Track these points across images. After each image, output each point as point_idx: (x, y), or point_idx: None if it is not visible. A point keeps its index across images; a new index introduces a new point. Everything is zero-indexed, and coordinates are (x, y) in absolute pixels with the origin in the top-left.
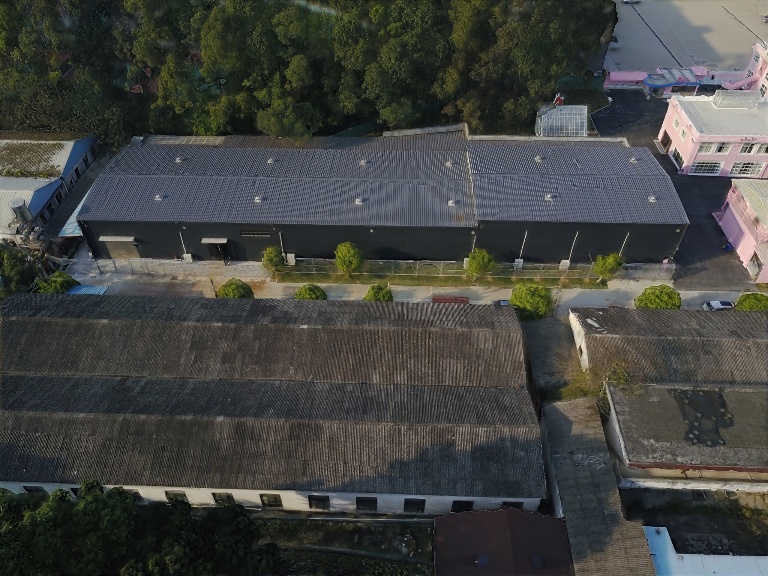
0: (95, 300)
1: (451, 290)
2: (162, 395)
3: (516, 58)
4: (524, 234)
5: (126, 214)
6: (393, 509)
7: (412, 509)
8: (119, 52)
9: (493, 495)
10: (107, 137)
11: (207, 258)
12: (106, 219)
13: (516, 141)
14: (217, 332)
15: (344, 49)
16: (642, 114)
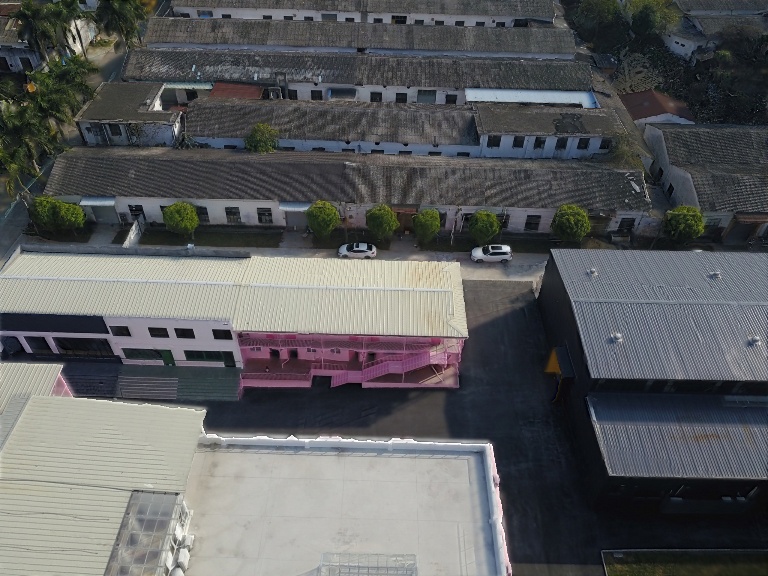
0: None
1: None
2: None
3: None
4: None
5: None
6: None
7: None
8: None
9: None
10: None
11: None
12: None
13: None
14: None
15: None
16: None
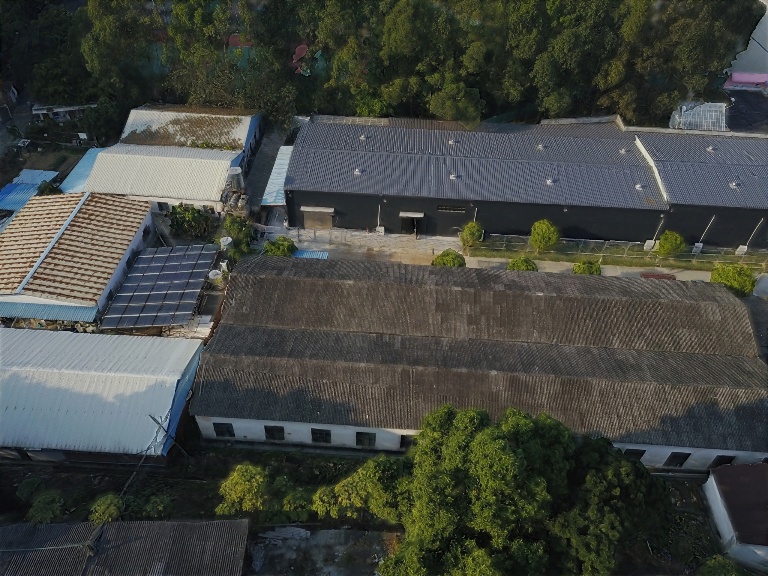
0: (326, 263)
1: (638, 270)
2: (425, 351)
3: (682, 53)
4: (711, 219)
5: (331, 186)
6: (654, 462)
7: (671, 463)
8: (303, 32)
9: (762, 450)
10: (278, 114)
11: (397, 231)
12: (313, 189)
13: (669, 134)
14: (458, 296)
15: (518, 38)
16: (767, 114)
